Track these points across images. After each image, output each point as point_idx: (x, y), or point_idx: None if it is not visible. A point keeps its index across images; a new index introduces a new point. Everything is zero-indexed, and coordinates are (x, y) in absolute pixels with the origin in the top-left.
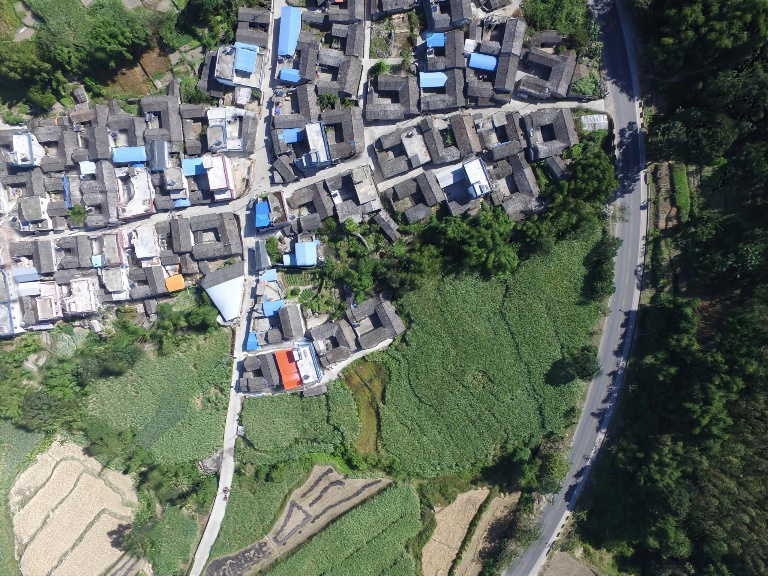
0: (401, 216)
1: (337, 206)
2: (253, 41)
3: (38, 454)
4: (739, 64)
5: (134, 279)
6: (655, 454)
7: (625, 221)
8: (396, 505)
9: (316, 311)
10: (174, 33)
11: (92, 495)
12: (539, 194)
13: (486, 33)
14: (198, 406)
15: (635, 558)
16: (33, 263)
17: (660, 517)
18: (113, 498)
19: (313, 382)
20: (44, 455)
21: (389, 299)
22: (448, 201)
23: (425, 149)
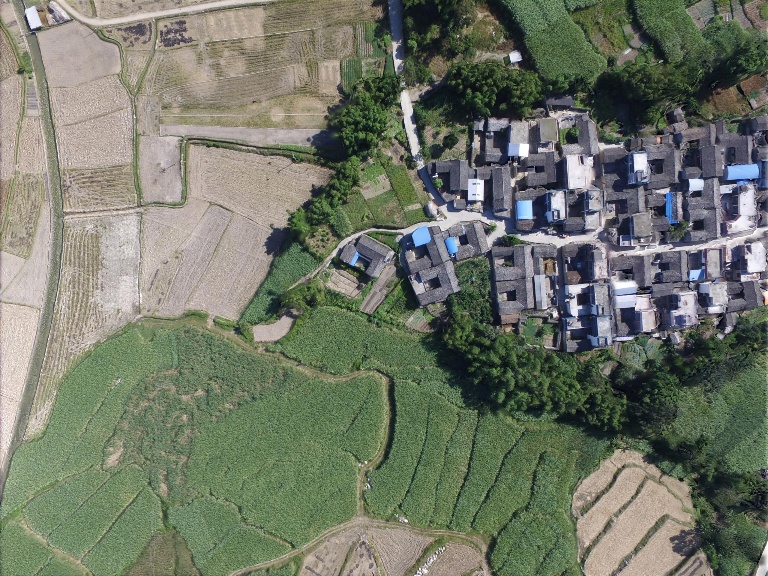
0: None
1: None
2: None
3: (600, 461)
4: None
5: (729, 293)
6: None
7: None
8: None
9: None
10: None
11: (655, 501)
12: None
13: None
14: None
15: None
16: (633, 277)
17: None
18: (674, 504)
19: None
20: (606, 462)
21: None
22: None
23: None
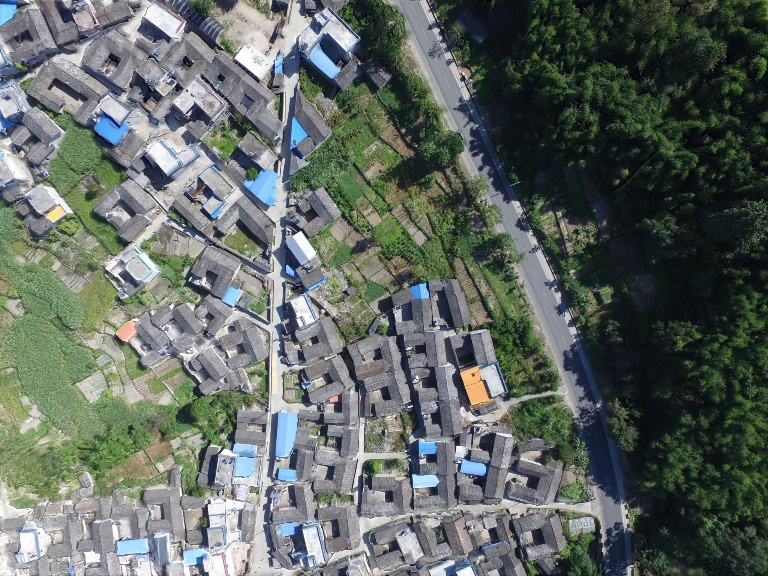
0: None
1: None
2: (251, 442)
3: None
4: (719, 513)
5: None
6: None
7: None
8: None
9: None
10: (175, 424)
11: None
12: None
13: (476, 438)
14: None
15: None
16: None
17: None
18: None
19: None
20: None
21: None
22: None
23: (419, 546)
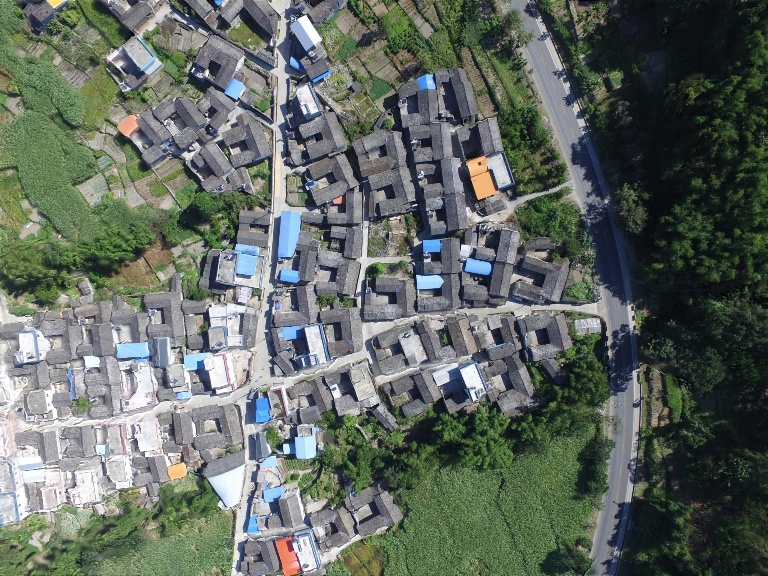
0: (399, 411)
1: (336, 401)
2: (254, 243)
3: None
4: (728, 292)
5: (137, 467)
6: None
7: (618, 421)
8: None
9: (315, 497)
10: (176, 229)
11: None
12: (534, 392)
13: (481, 238)
14: None
15: None
16: (38, 452)
17: None
18: None
19: (312, 569)
20: None
21: (387, 489)
22: (445, 398)
23: (422, 348)
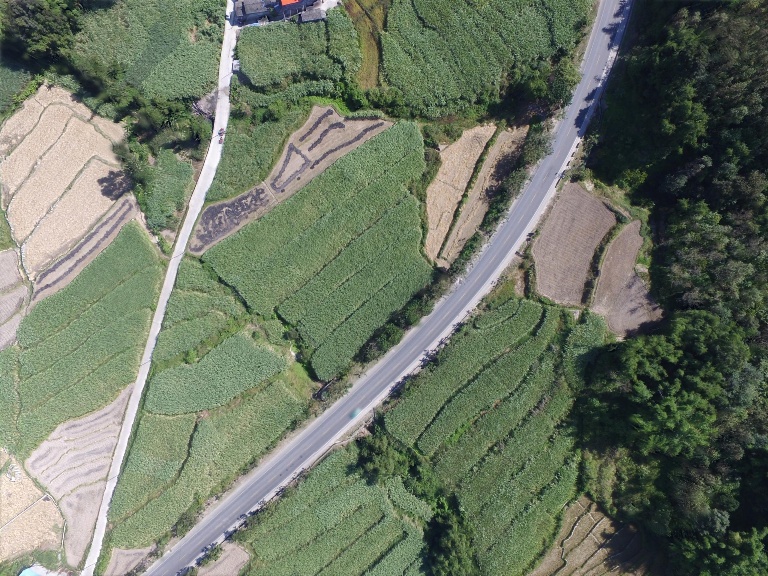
0: None
1: None
2: None
3: (25, 100)
4: None
5: None
6: (671, 31)
7: None
8: (399, 142)
9: None
10: None
11: (81, 141)
12: None
13: None
14: (191, 38)
15: (649, 183)
16: None
17: (676, 95)
18: (103, 145)
19: None
20: (31, 100)
21: None
22: None
23: None
